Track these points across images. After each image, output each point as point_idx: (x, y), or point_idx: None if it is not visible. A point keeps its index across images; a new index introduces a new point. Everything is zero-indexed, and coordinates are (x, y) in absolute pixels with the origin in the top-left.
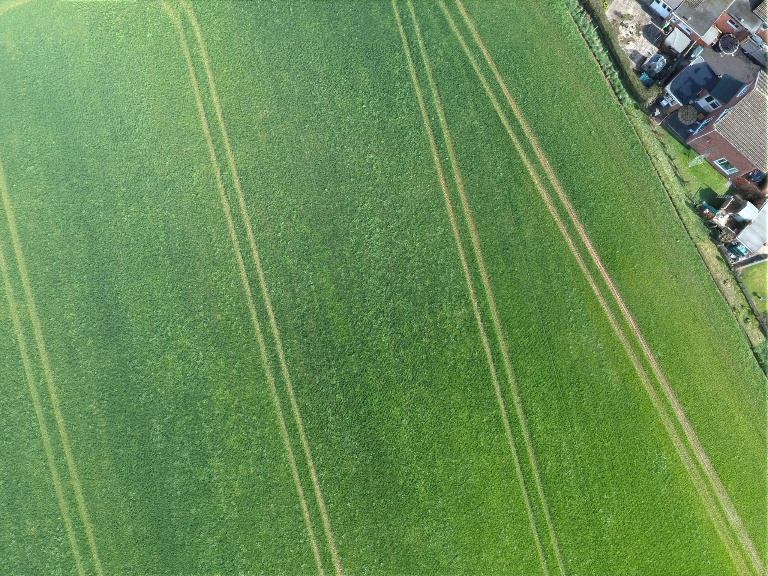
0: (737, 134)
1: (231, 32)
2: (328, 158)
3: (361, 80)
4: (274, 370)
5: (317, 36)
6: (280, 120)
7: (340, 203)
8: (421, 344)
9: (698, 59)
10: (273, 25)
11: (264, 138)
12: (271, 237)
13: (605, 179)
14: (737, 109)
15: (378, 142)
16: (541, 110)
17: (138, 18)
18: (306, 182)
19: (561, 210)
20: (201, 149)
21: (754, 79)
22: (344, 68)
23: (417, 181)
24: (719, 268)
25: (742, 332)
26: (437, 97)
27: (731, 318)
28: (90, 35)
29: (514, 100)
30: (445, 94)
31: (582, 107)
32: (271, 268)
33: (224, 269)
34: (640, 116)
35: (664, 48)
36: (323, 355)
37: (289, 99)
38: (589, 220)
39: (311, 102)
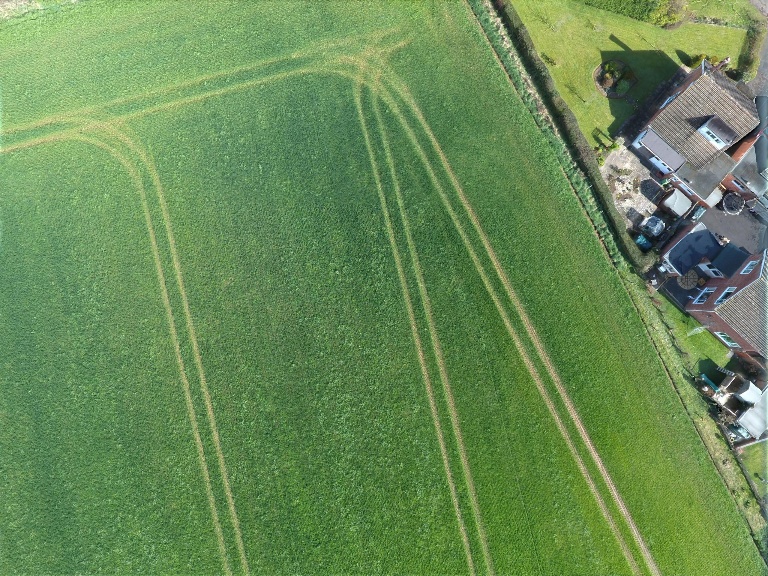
0: (740, 320)
1: (195, 192)
2: (297, 330)
3: (334, 244)
4: (232, 563)
5: (288, 196)
6: (246, 288)
7: (308, 379)
8: (393, 534)
9: (699, 226)
10: (241, 184)
11: (228, 308)
12: (233, 417)
13: (596, 350)
14: (740, 296)
15: (351, 312)
16: (529, 275)
17: (95, 177)
18: (272, 356)
19: (548, 384)
20: (159, 321)
21: (759, 259)
22: (316, 231)
23: (393, 354)
24: (718, 447)
25: (742, 517)
26: (416, 261)
27: (730, 502)
28: (42, 196)
29: (500, 264)
30: (425, 258)
31: (573, 271)
32: (232, 451)
33: (181, 453)
34: (636, 281)
35: (663, 207)
36: (286, 547)
37: (256, 265)
38: (578, 395)
39: (280, 268)
